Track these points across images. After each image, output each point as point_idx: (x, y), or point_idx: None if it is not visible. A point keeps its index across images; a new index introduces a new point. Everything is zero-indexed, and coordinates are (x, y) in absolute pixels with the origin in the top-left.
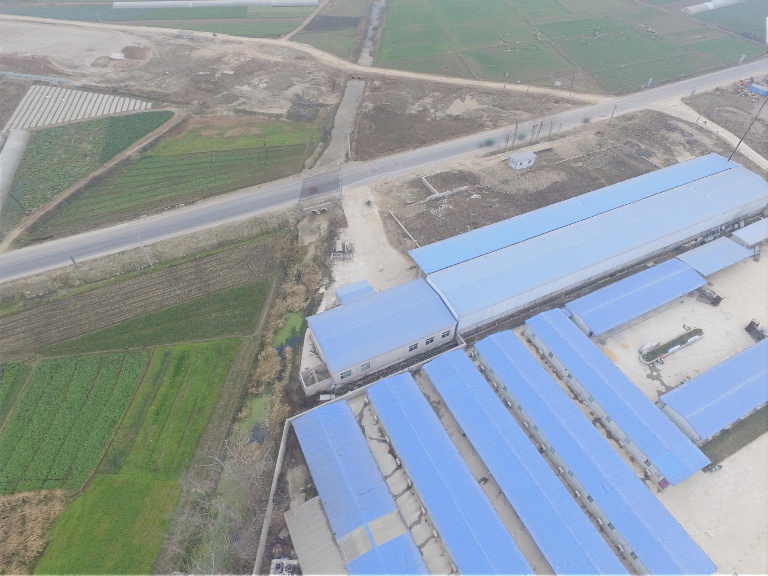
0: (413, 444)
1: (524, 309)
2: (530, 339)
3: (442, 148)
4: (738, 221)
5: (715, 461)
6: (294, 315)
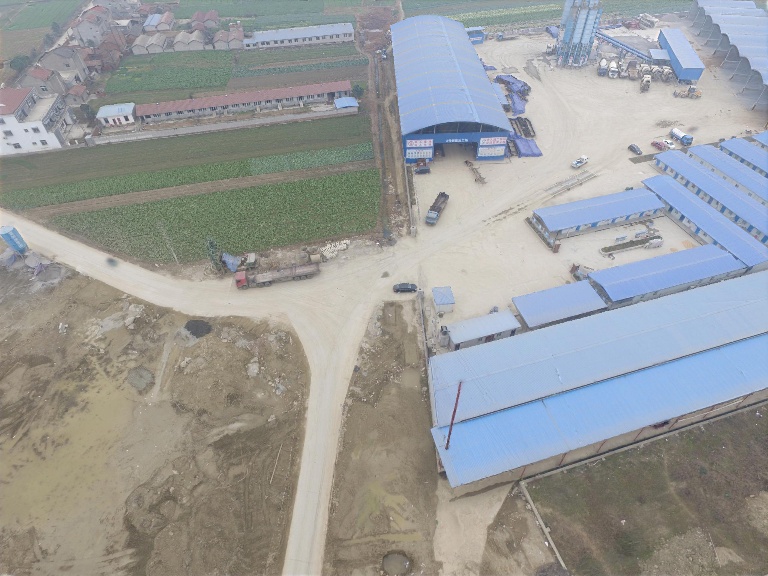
0: None
1: None
2: None
3: None
4: None
5: None
6: None
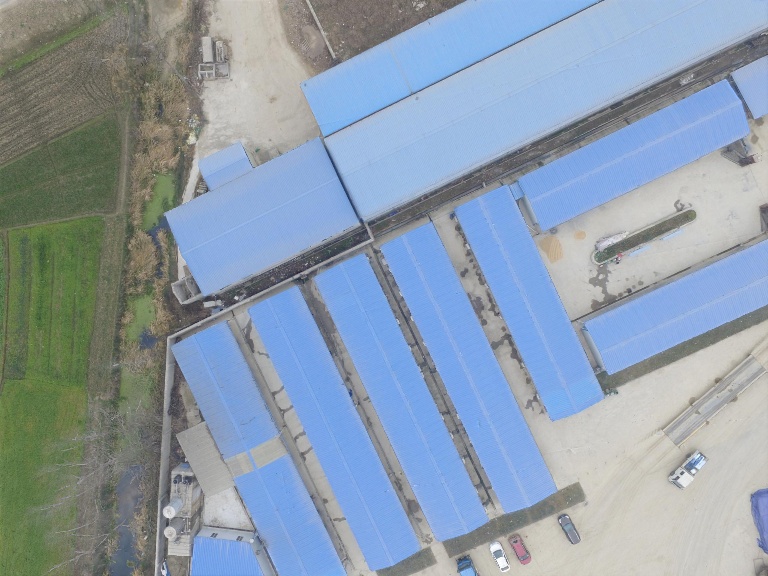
0: (295, 376)
1: (464, 175)
2: (460, 225)
3: None
4: None
5: (616, 384)
6: (163, 178)
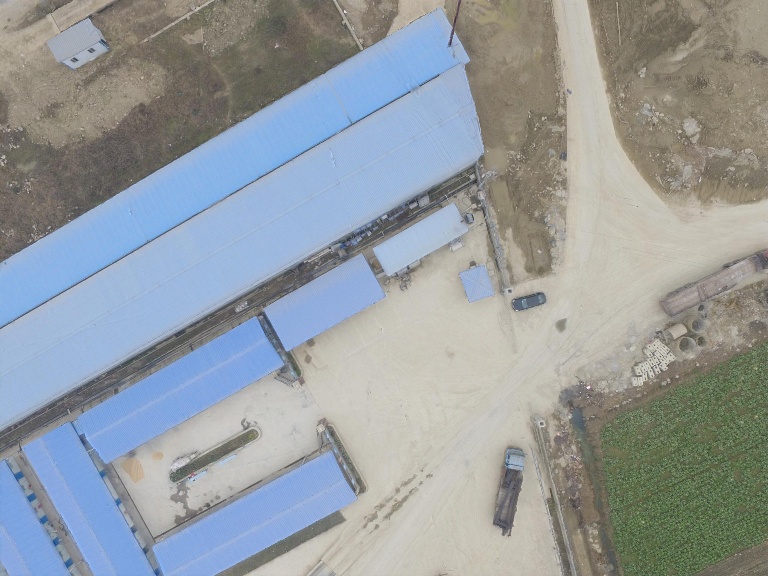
0: None
1: (44, 407)
2: None
3: None
4: (416, 199)
5: None
6: None
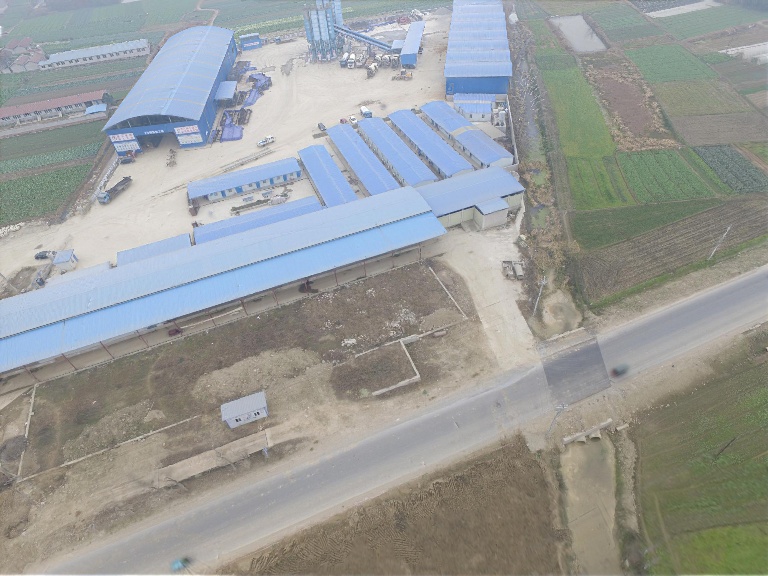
0: None
1: None
2: None
3: (370, 477)
4: None
5: None
6: None
